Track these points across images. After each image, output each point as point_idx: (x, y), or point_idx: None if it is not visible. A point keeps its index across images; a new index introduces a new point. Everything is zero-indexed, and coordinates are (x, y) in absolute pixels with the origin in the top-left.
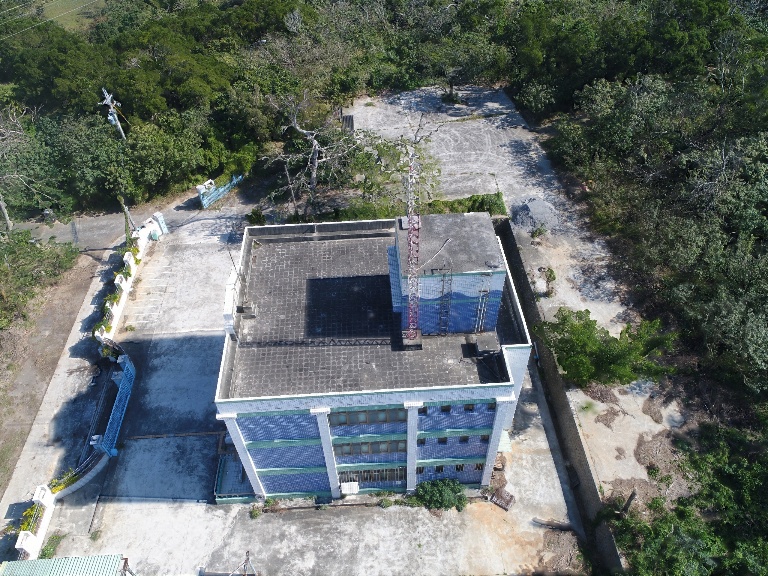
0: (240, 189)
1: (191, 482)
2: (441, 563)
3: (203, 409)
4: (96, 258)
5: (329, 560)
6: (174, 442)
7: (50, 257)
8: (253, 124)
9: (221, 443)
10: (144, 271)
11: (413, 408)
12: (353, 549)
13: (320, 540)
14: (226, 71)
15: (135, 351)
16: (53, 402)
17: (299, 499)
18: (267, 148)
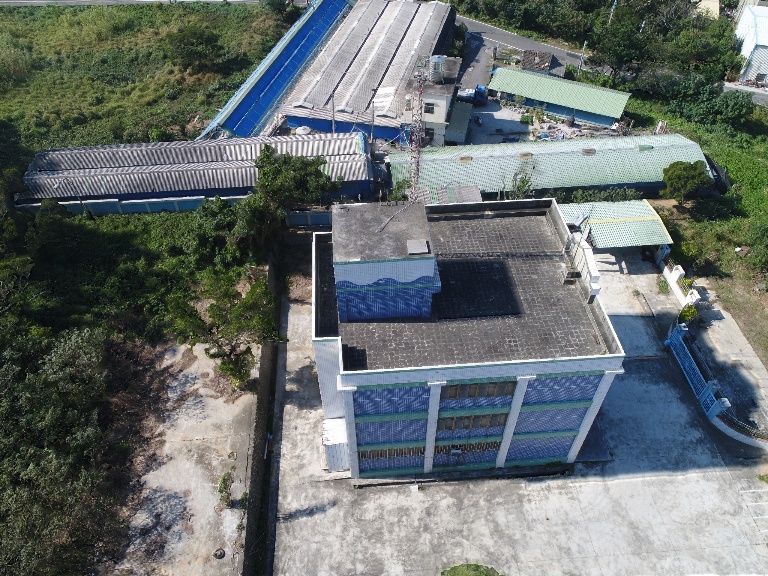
0: None
1: None
2: None
3: None
4: None
5: None
6: None
7: None
8: None
9: None
10: None
11: None
12: None
13: None
14: None
15: (732, 446)
16: None
17: None
18: None
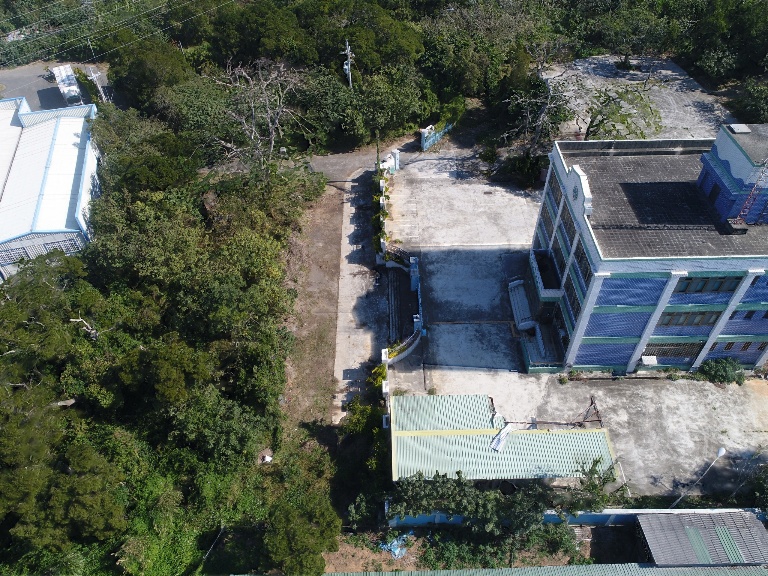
0: (451, 136)
1: (498, 357)
2: (737, 421)
3: (487, 304)
4: (340, 188)
5: (640, 416)
6: (472, 327)
7: (299, 186)
8: (468, 78)
9: (513, 329)
10: (391, 198)
11: (755, 274)
12: (658, 409)
13: (627, 402)
14: (415, 36)
15: None
16: (348, 296)
17: (597, 372)
18: (466, 103)
